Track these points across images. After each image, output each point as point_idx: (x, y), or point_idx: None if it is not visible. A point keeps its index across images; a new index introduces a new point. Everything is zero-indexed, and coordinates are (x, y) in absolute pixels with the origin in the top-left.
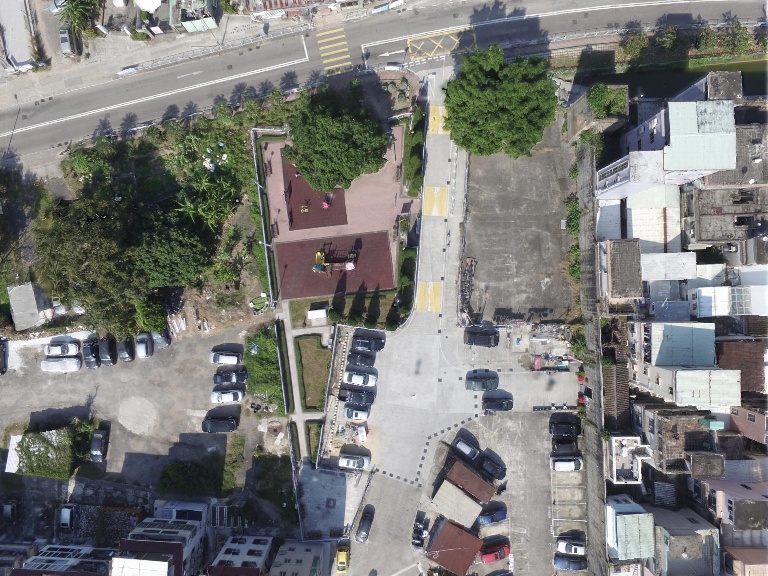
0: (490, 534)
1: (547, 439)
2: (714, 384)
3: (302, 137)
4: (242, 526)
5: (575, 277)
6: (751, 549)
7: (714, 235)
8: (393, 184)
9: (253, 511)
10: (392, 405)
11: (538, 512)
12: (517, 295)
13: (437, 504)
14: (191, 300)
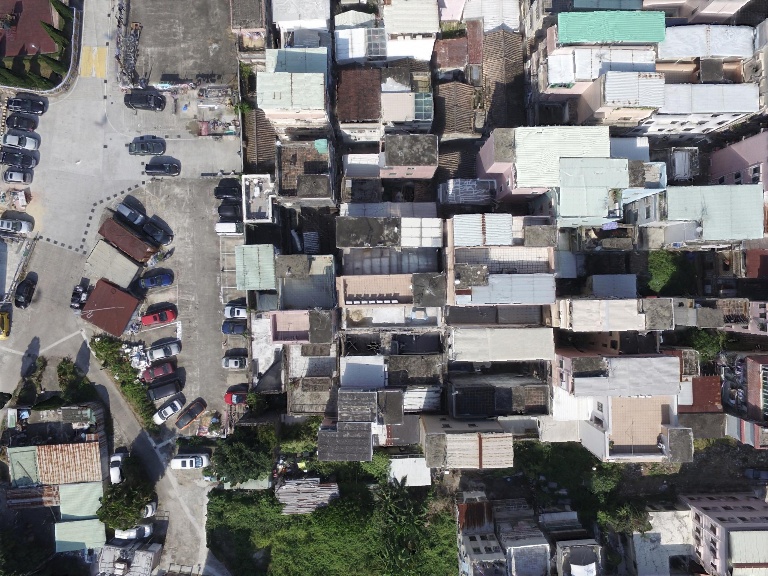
0: (157, 301)
1: (216, 206)
2: (296, 86)
3: None
4: None
5: None
6: None
7: None
8: None
9: None
10: (56, 171)
11: (207, 279)
12: (184, 61)
13: (91, 263)
14: None
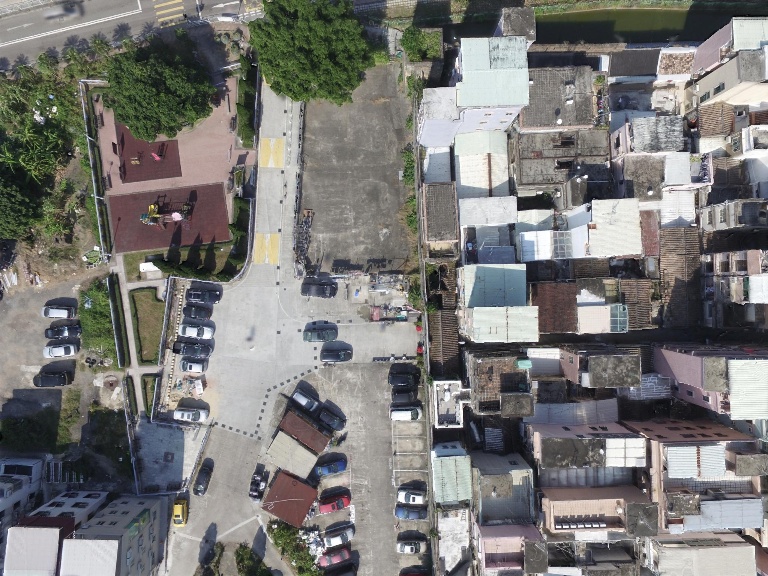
0: (331, 486)
1: (387, 390)
2: (511, 320)
3: (112, 82)
4: (77, 481)
5: (413, 227)
6: (566, 489)
7: (535, 179)
8: (228, 136)
9: (89, 466)
10: (230, 358)
11: (379, 463)
12: (355, 246)
13: (272, 455)
14: (23, 254)
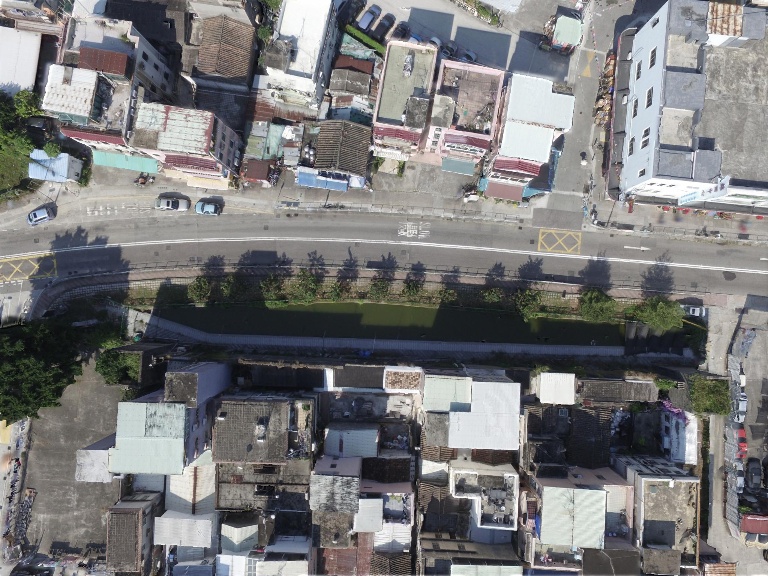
0: None
1: None
2: None
3: None
4: None
5: None
6: None
7: (233, 503)
8: None
9: None
10: None
11: None
12: (76, 529)
13: None
14: None
